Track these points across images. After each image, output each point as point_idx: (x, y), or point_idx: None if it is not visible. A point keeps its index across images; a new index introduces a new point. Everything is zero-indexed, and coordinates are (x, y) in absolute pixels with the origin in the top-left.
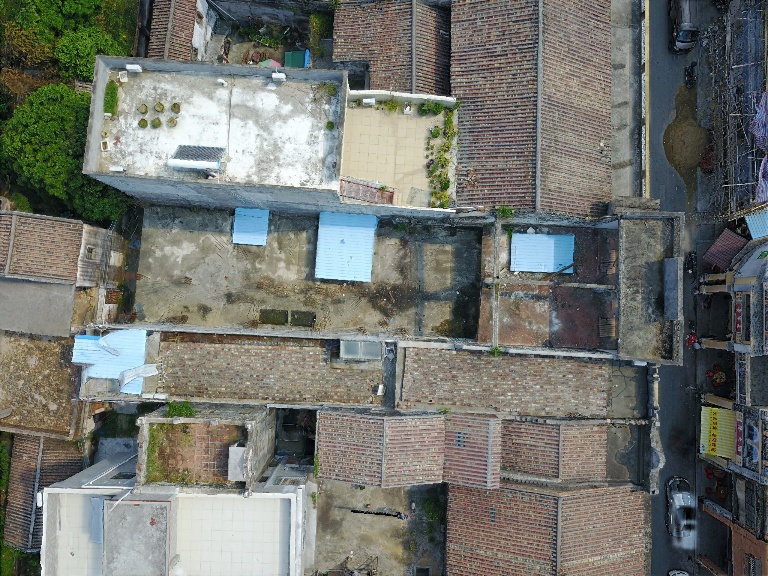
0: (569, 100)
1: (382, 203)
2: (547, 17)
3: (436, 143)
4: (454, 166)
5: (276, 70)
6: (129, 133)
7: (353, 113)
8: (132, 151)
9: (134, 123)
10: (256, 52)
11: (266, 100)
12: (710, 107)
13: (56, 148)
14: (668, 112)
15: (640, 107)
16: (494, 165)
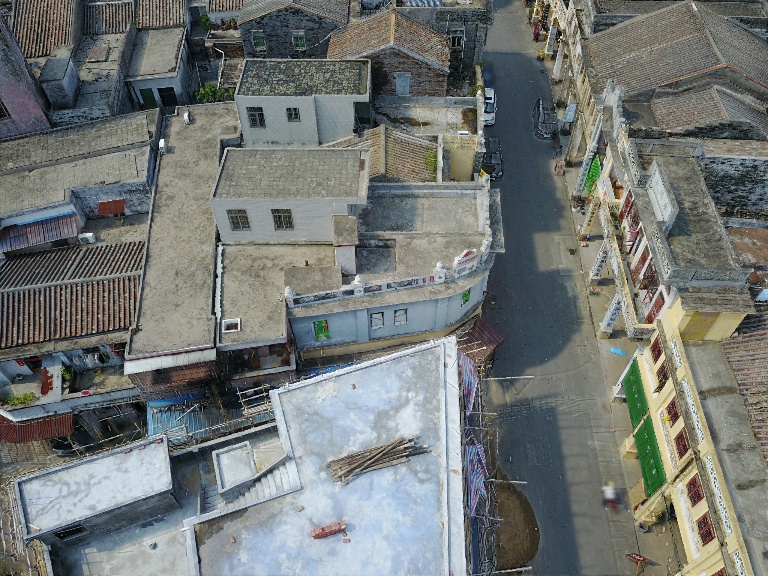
0: None
1: None
2: None
3: None
4: None
5: None
6: None
7: None
8: None
9: None
10: None
11: None
12: None
13: None
14: None
15: None
16: None
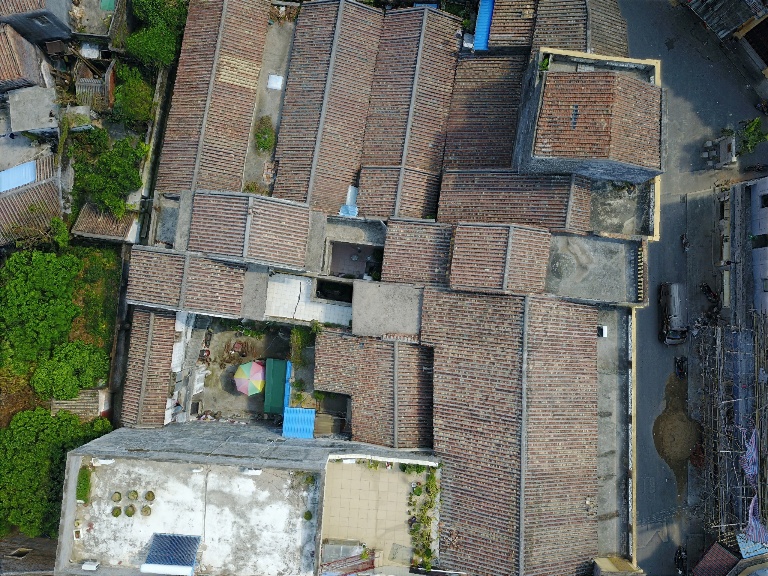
0: (554, 467)
1: (363, 569)
2: (531, 389)
3: (418, 498)
4: (437, 522)
5: (252, 468)
6: (102, 519)
7: (333, 466)
8: (106, 538)
9: (108, 509)
10: (238, 342)
11: (243, 486)
12: (701, 399)
13: (31, 494)
14: (658, 403)
15: (627, 457)
16: (477, 532)
